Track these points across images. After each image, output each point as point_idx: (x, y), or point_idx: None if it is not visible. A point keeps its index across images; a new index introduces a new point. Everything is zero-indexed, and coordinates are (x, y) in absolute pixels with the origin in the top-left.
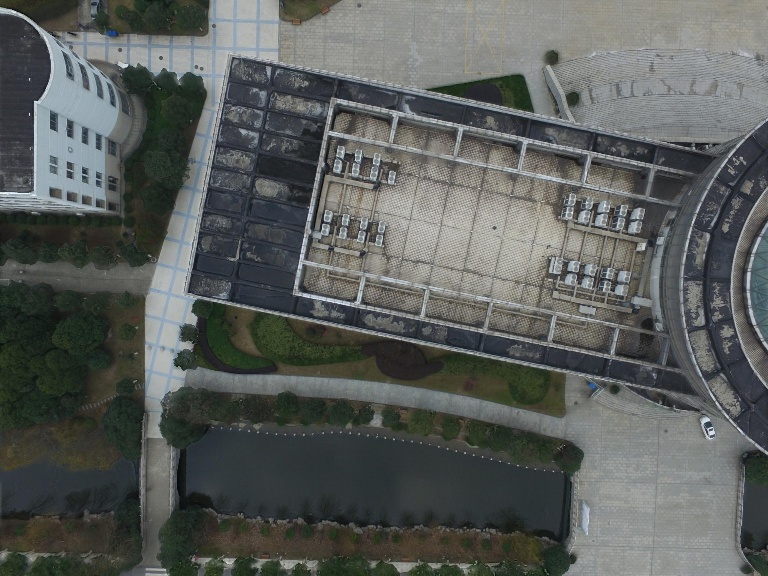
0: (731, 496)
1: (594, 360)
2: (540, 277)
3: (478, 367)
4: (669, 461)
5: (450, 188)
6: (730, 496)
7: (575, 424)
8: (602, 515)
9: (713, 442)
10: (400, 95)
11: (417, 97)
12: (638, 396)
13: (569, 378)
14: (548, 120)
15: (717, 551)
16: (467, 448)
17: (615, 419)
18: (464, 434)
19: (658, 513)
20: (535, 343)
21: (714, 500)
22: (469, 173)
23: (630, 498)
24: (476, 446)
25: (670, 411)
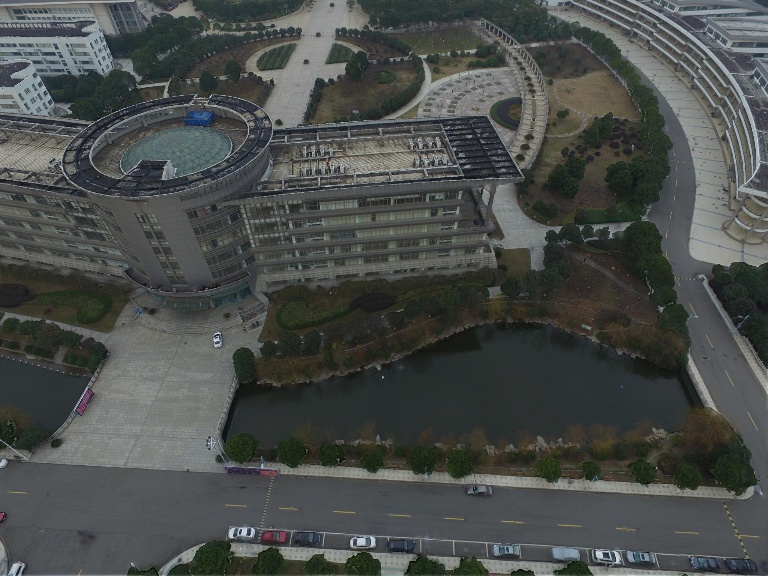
0: (225, 393)
1: (42, 188)
2: (45, 170)
3: (61, 298)
4: (180, 364)
5: (25, 146)
6: (224, 393)
7: (116, 337)
8: (105, 406)
9: (221, 352)
10: (20, 118)
11: (28, 119)
12: (137, 284)
13: (126, 309)
14: (76, 121)
15: (199, 441)
16: (25, 359)
17: (149, 335)
18: (26, 344)
19: (155, 405)
20: (13, 180)
21: (209, 396)
22: (39, 142)
23: (136, 392)
24: (33, 358)
25: (191, 328)
